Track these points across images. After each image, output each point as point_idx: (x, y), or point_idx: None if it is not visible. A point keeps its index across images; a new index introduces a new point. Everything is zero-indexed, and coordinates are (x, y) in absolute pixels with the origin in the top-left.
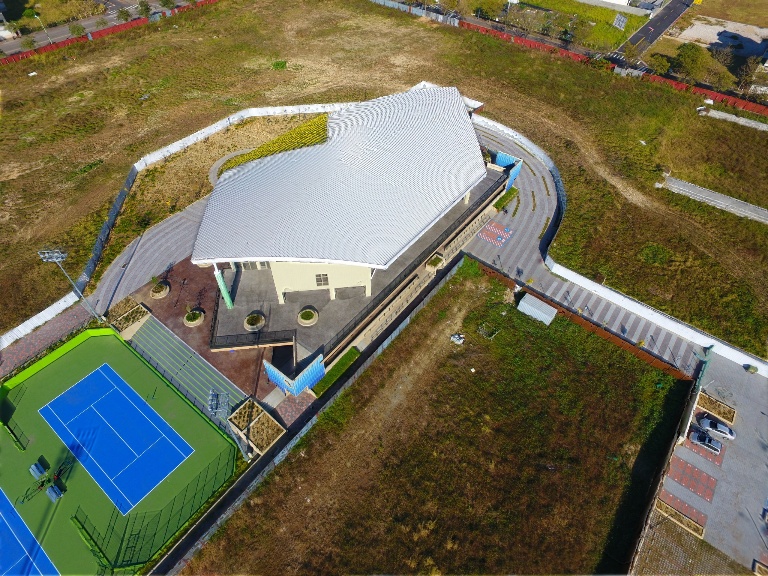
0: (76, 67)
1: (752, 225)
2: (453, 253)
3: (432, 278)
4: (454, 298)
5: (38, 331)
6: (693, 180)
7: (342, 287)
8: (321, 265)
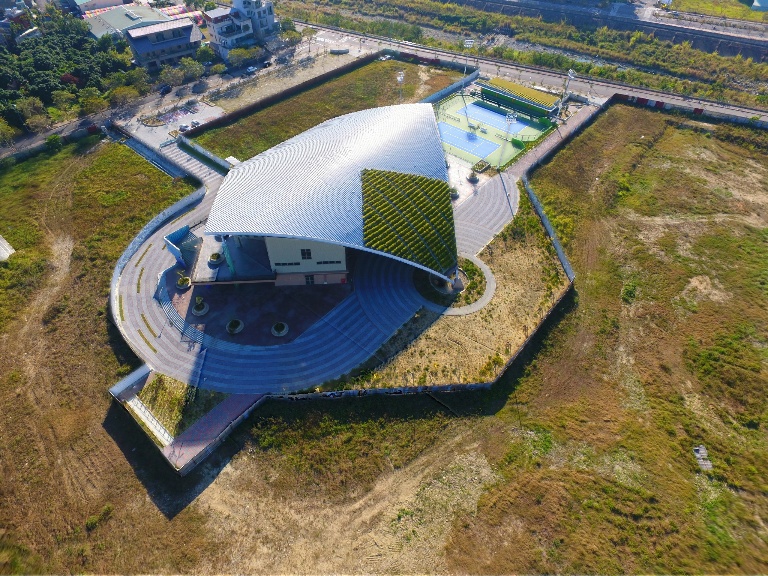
0: None
1: None
2: None
3: None
4: None
5: None
6: None
7: None
8: None
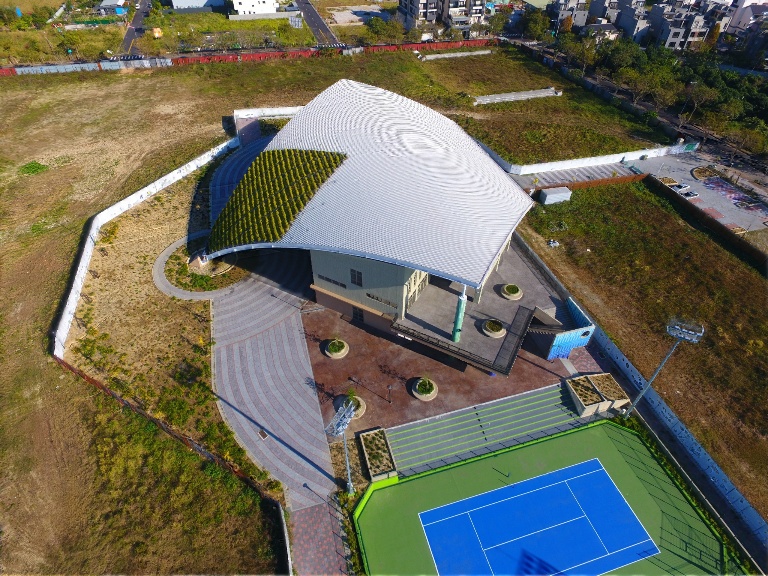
0: None
1: (536, 100)
2: None
3: None
4: None
5: None
6: (481, 94)
7: None
8: None
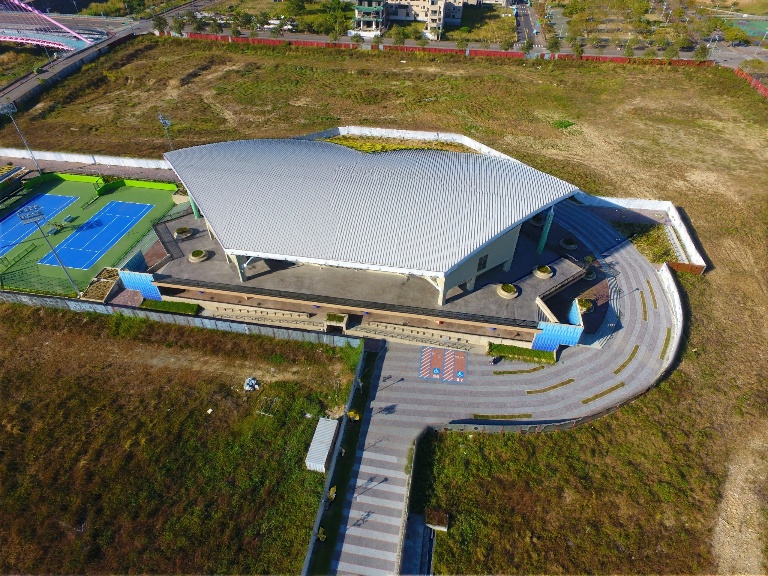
0: (430, 67)
1: None
2: (368, 332)
3: (320, 329)
4: (306, 360)
5: (169, 171)
6: None
7: None
8: None
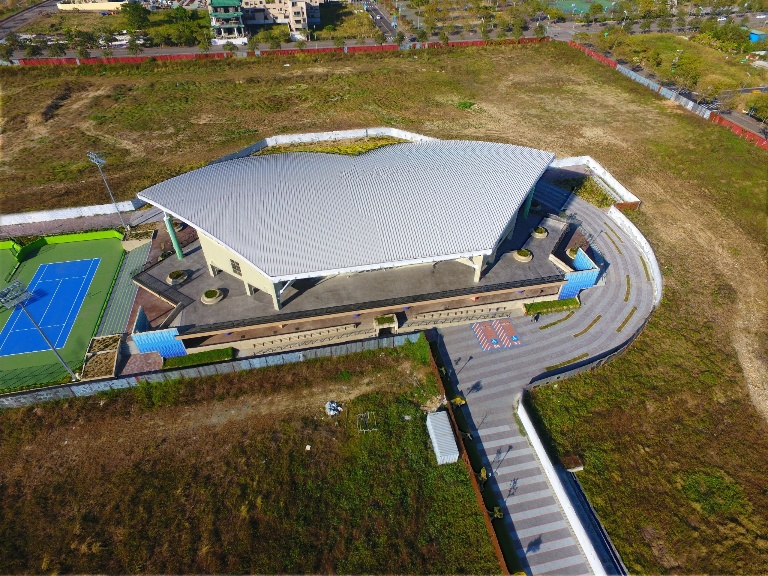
0: (316, 68)
1: None
2: (419, 325)
3: (372, 335)
4: (374, 368)
5: (96, 217)
6: None
7: (253, 285)
8: None
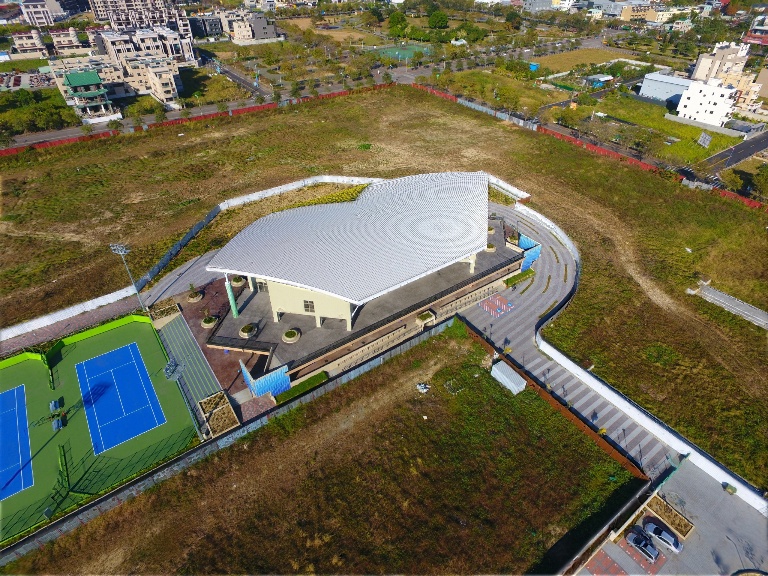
0: (212, 133)
1: None
2: (447, 314)
3: (419, 331)
4: (434, 352)
5: (101, 309)
6: (735, 293)
7: (326, 317)
8: (308, 292)
